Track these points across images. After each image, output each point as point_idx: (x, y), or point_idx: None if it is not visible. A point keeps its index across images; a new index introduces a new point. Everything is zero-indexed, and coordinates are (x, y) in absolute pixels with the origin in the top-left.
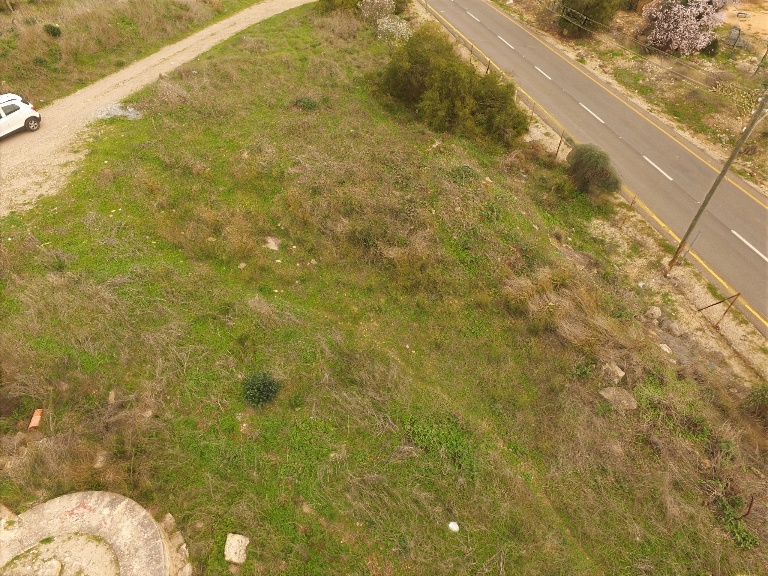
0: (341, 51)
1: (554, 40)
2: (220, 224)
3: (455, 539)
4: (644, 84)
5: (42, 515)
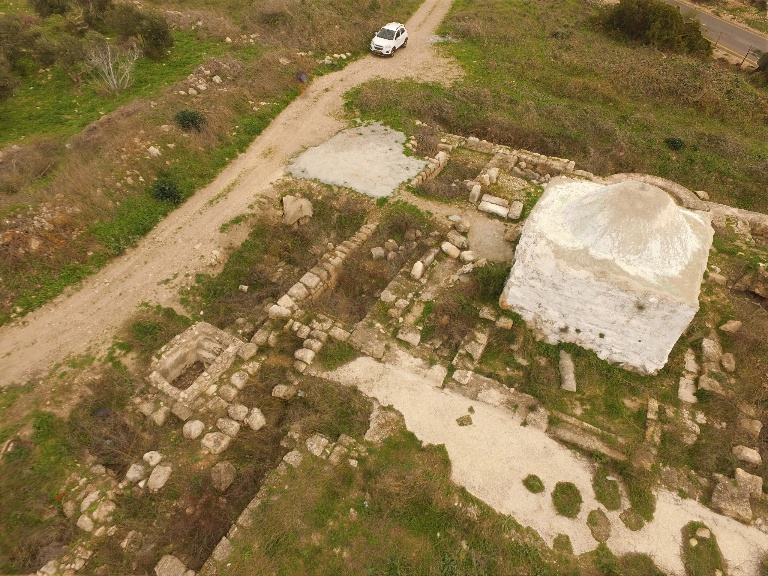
0: (548, 7)
1: (690, 3)
2: (583, 87)
3: None
4: None
5: (615, 178)
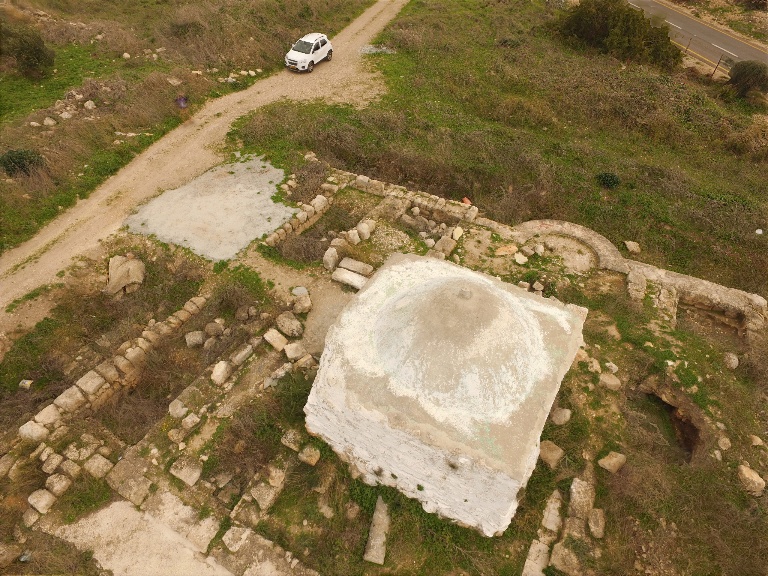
0: (506, 10)
1: (668, 2)
2: (516, 107)
3: (763, 236)
4: (757, 31)
5: (525, 227)
